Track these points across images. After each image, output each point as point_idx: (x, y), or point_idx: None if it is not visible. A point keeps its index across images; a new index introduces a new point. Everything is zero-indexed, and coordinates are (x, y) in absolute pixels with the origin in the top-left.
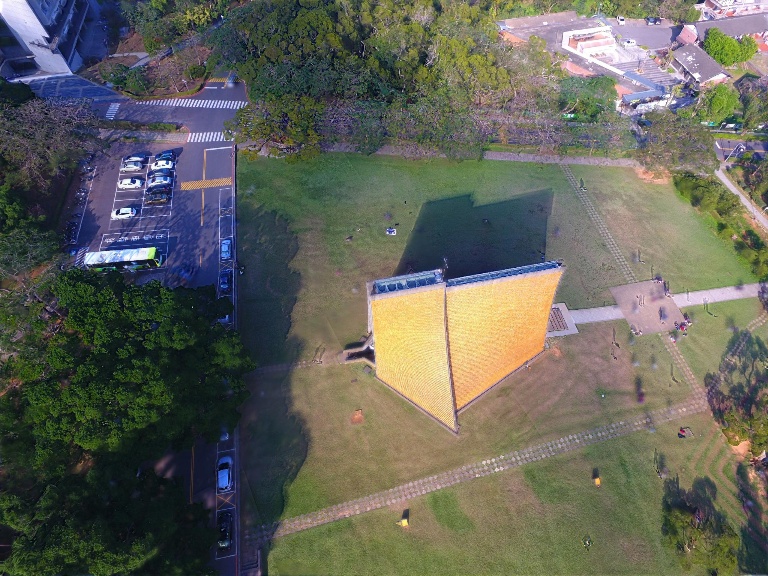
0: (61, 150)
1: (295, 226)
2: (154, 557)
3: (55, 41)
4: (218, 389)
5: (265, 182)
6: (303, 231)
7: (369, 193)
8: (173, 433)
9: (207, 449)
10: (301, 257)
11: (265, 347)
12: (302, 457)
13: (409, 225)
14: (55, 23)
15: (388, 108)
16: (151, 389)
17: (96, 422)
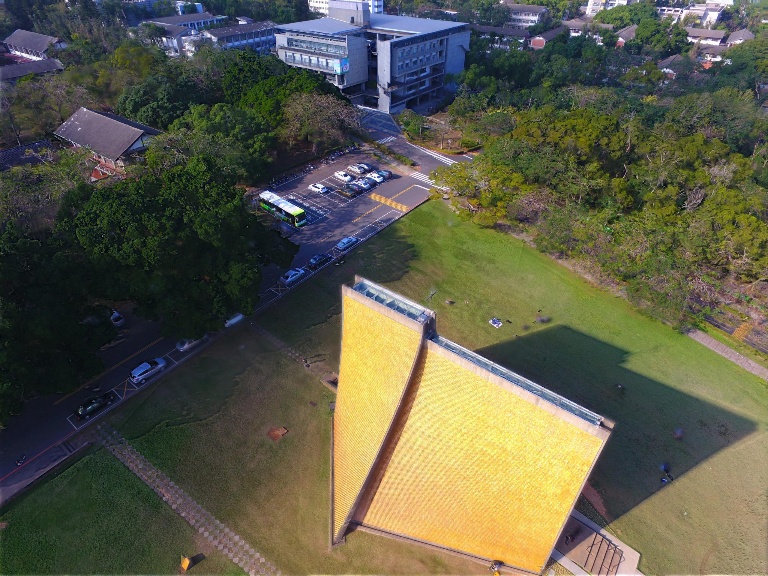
0: (315, 125)
1: (416, 264)
2: (8, 333)
3: (393, 88)
4: (204, 299)
5: (431, 224)
6: (418, 271)
7: (511, 283)
8: (136, 289)
9: (165, 346)
10: (393, 286)
11: (287, 320)
12: (203, 416)
13: (521, 330)
14: (405, 82)
15: (592, 216)
16: (149, 240)
17: (101, 230)
